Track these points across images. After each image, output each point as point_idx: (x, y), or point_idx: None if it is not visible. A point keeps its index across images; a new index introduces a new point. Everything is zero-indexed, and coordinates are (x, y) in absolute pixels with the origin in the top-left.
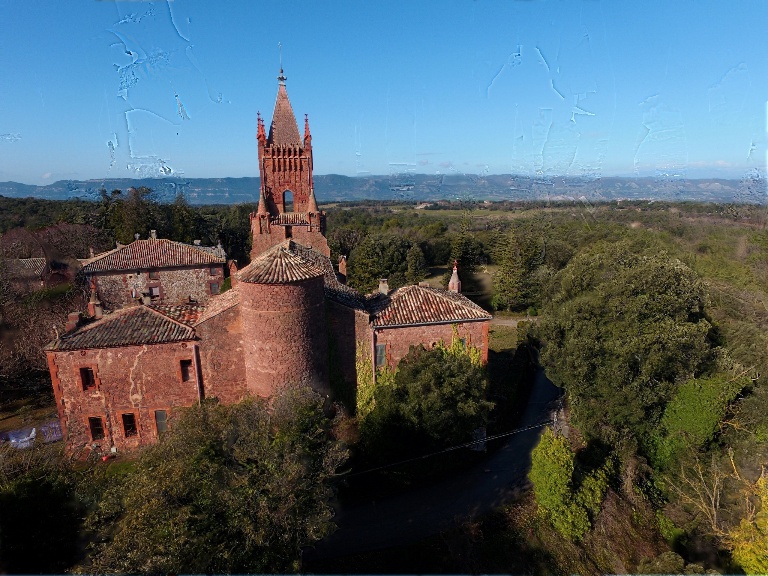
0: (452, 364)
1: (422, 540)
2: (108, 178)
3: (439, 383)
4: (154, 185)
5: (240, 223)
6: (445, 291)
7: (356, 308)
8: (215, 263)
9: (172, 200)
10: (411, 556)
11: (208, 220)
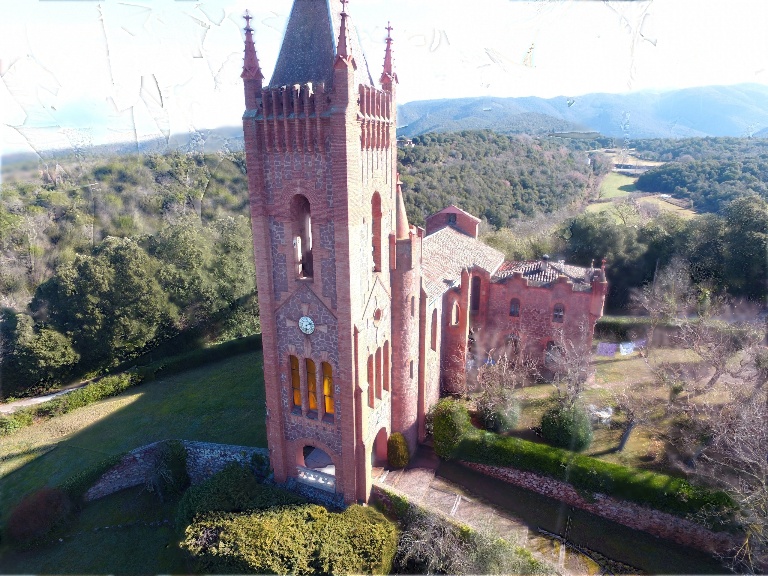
0: None
1: None
2: None
3: None
4: None
5: None
6: None
7: None
8: None
9: None
10: None
11: None
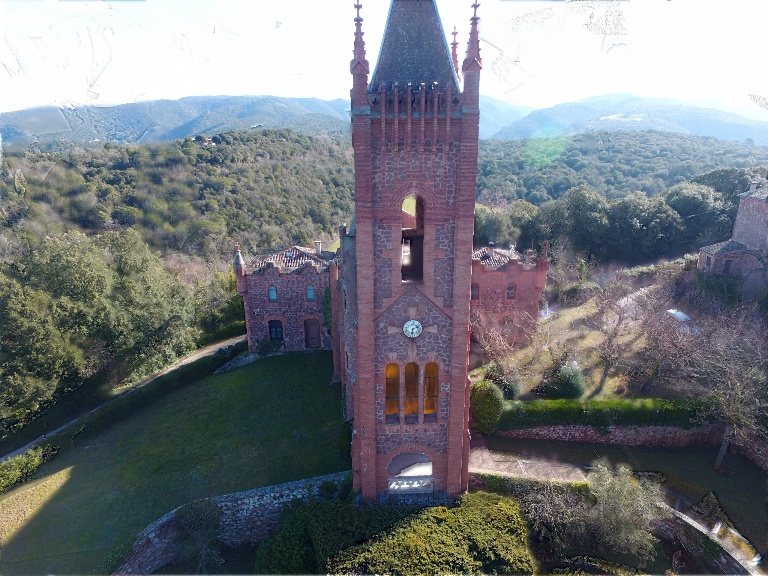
0: None
1: None
2: None
3: None
4: None
5: None
6: None
7: None
8: None
9: None
10: None
11: None
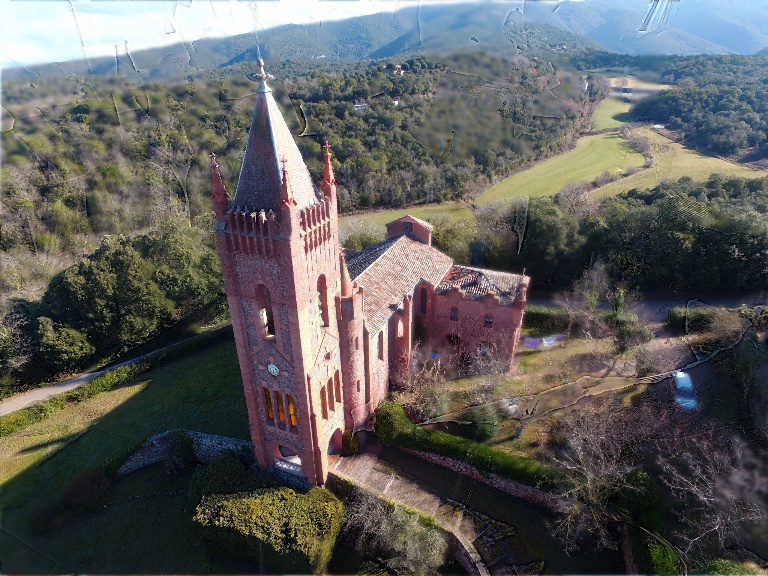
0: None
1: None
2: None
3: None
4: None
5: None
6: None
7: None
8: None
9: None
10: None
11: None
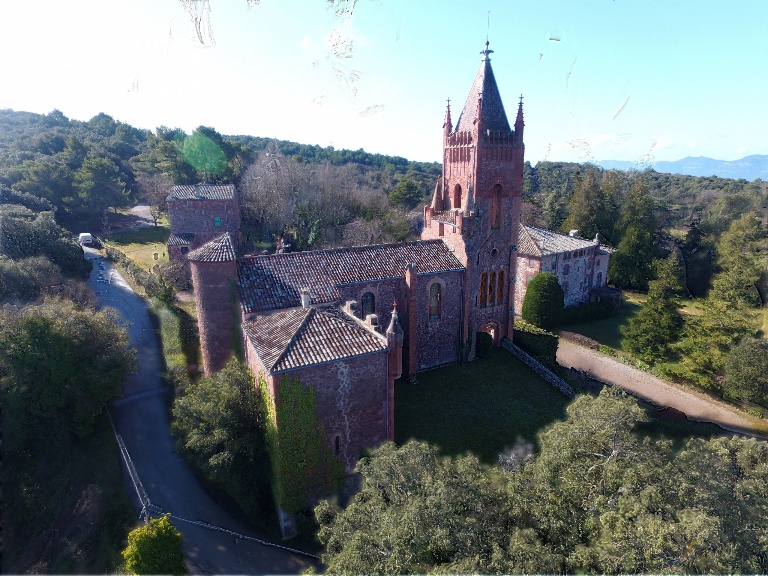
0: (220, 392)
1: (127, 496)
2: (548, 161)
3: (204, 399)
4: (585, 168)
5: (719, 219)
6: (360, 334)
7: (244, 303)
8: (532, 255)
9: (602, 185)
10: (112, 493)
11: (674, 210)
